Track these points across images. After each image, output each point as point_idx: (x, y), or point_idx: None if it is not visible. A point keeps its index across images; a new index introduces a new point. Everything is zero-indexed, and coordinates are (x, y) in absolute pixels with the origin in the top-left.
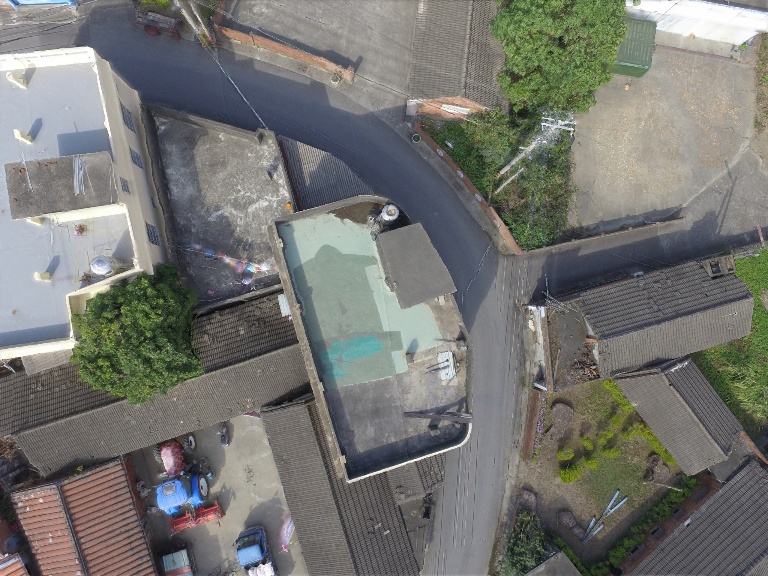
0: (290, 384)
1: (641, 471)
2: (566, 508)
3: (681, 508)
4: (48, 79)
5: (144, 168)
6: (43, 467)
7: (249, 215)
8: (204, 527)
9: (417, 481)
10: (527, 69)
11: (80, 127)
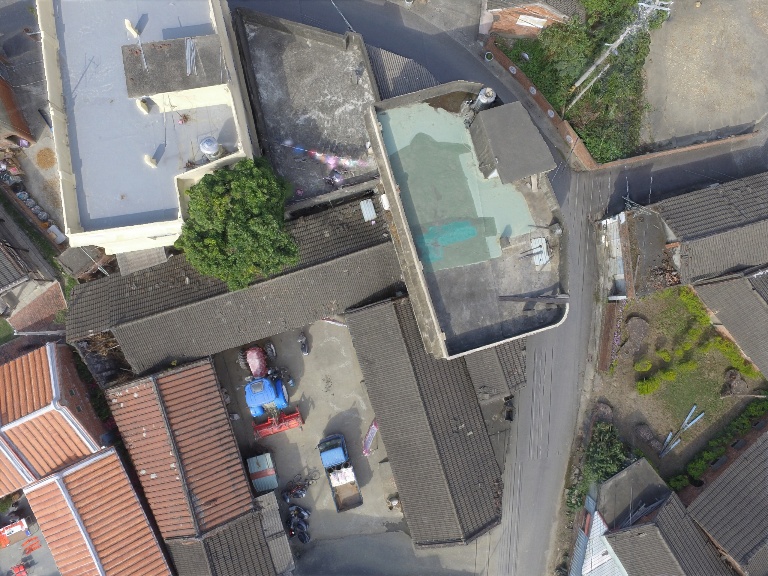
0: (374, 287)
1: (718, 386)
2: (642, 422)
3: (762, 420)
4: None
5: (236, 71)
6: (137, 363)
7: (336, 118)
8: (284, 435)
9: (501, 380)
10: None
11: (184, 22)
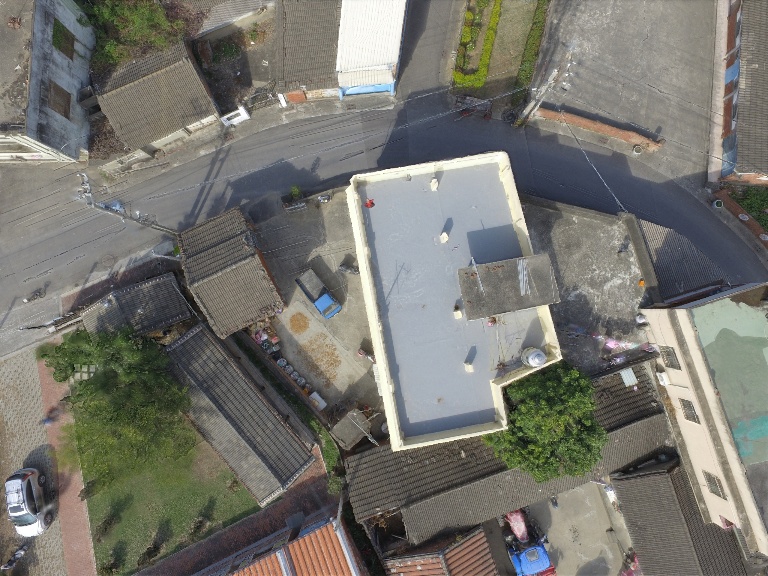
0: (639, 452)
1: None
2: None
3: None
4: (455, 181)
5: None
6: (418, 536)
7: (605, 293)
8: None
9: None
10: None
11: (486, 224)
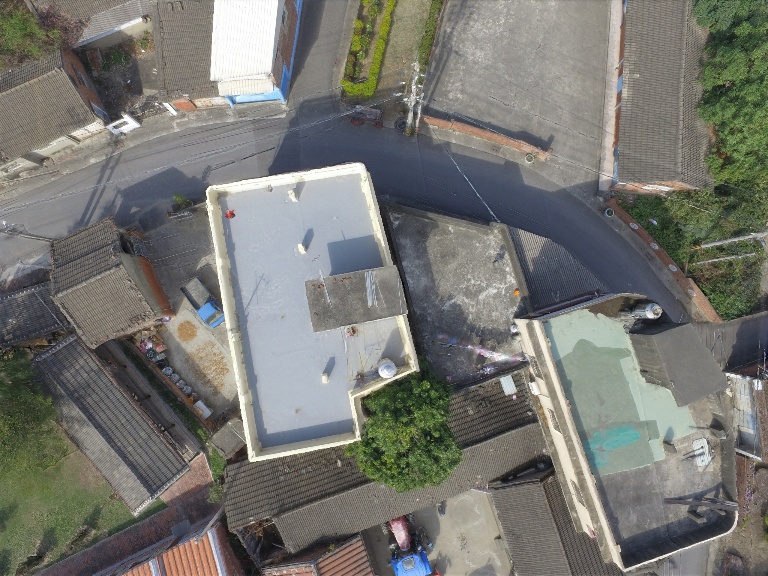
0: (517, 461)
1: None
2: None
3: None
4: (317, 192)
5: None
6: (294, 545)
7: (480, 303)
8: None
9: None
10: (745, 153)
11: (347, 235)
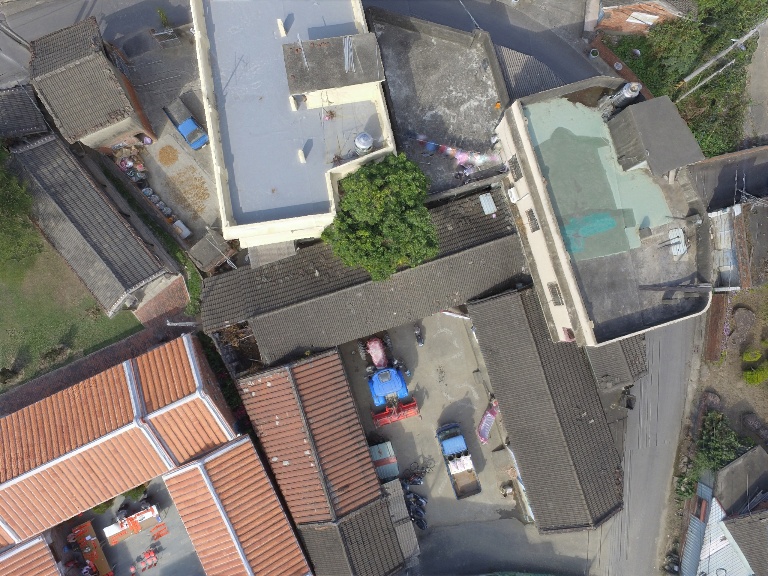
0: (496, 278)
1: None
2: (750, 411)
3: None
4: None
5: None
6: (269, 354)
7: (461, 114)
8: (399, 425)
9: (625, 369)
10: None
11: (328, 21)
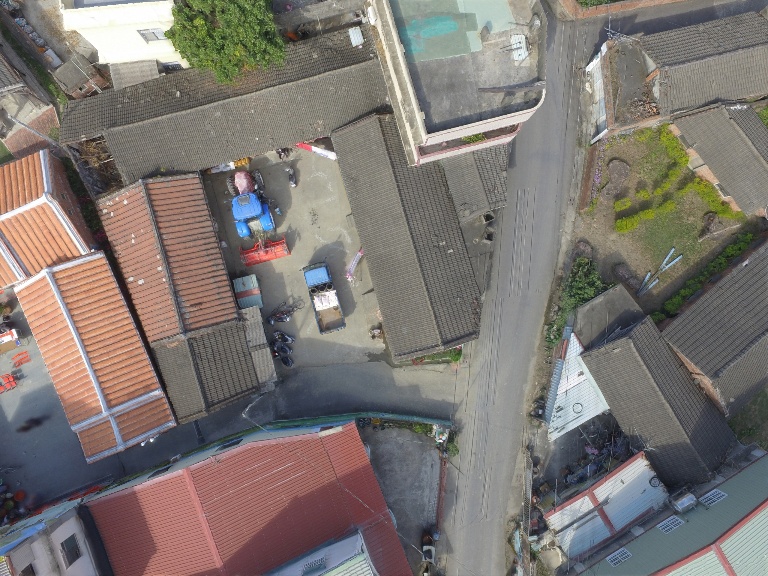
0: (360, 108)
1: (696, 230)
2: (622, 262)
3: None
4: None
5: None
6: (128, 172)
7: None
8: (270, 265)
9: (482, 195)
10: None
11: None
